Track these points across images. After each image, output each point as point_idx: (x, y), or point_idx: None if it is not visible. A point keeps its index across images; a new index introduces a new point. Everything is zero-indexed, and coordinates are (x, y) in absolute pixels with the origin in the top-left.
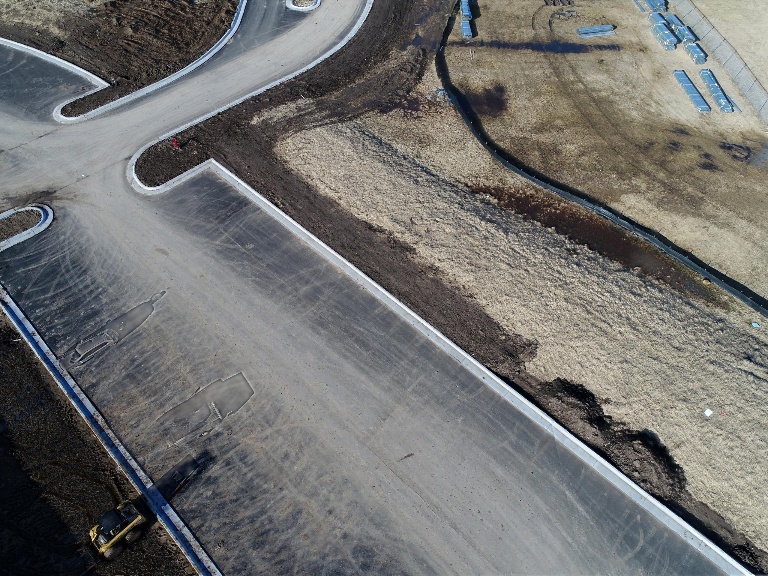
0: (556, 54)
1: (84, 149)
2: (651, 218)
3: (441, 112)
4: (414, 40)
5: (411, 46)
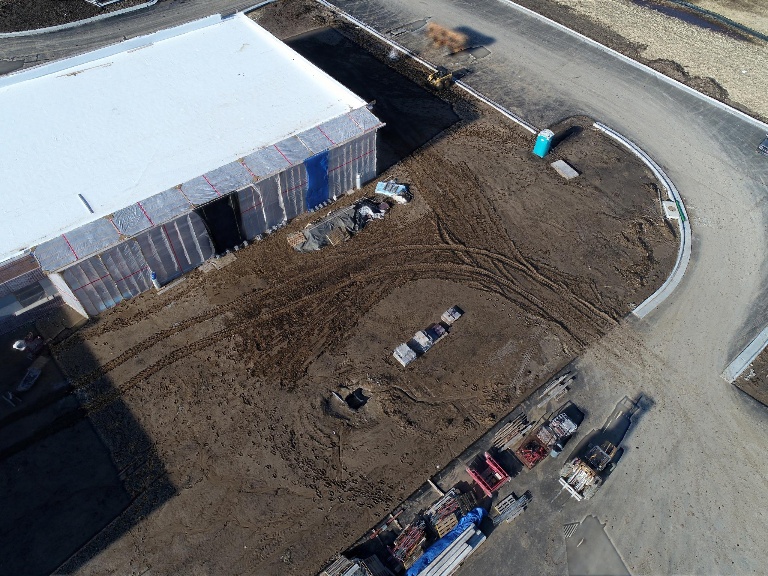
0: None
1: None
2: (719, 10)
3: None
4: None
5: None
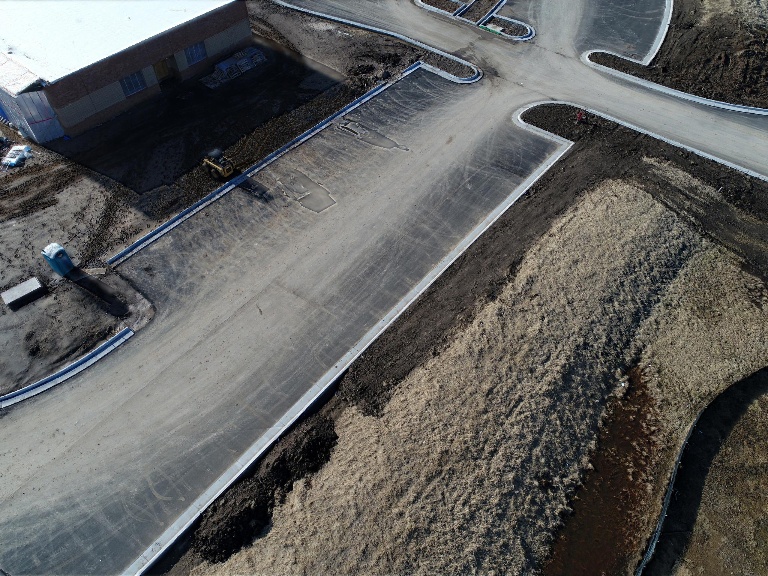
0: None
1: (554, 76)
2: None
3: None
4: None
5: None
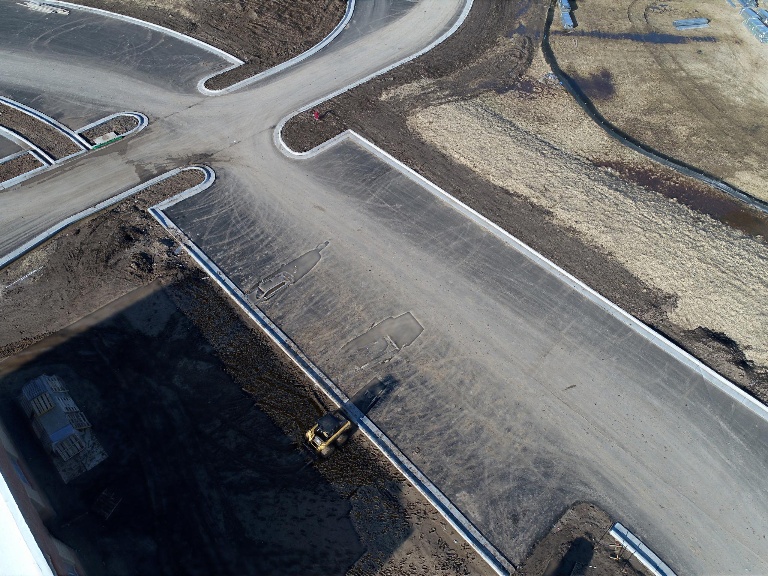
0: (655, 44)
1: (231, 118)
2: (767, 193)
3: (554, 94)
4: (518, 29)
5: (516, 34)
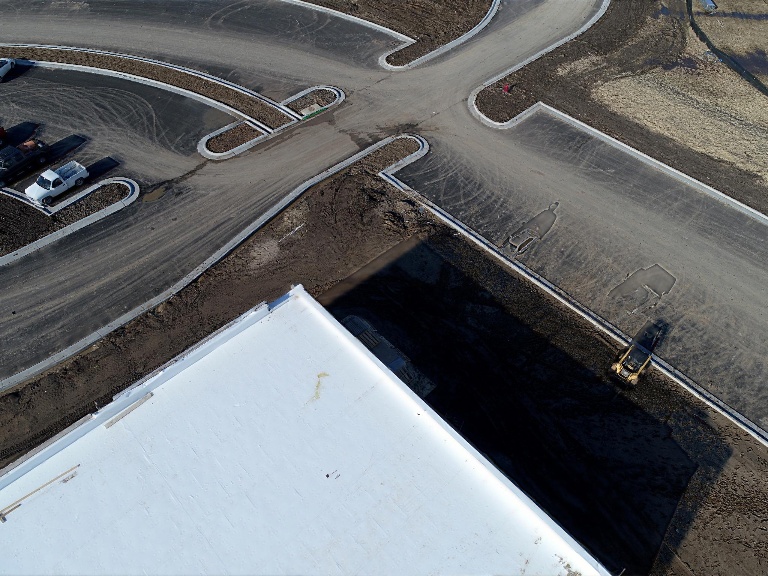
0: None
1: (423, 92)
2: None
3: (718, 70)
4: (662, 10)
5: (662, 15)
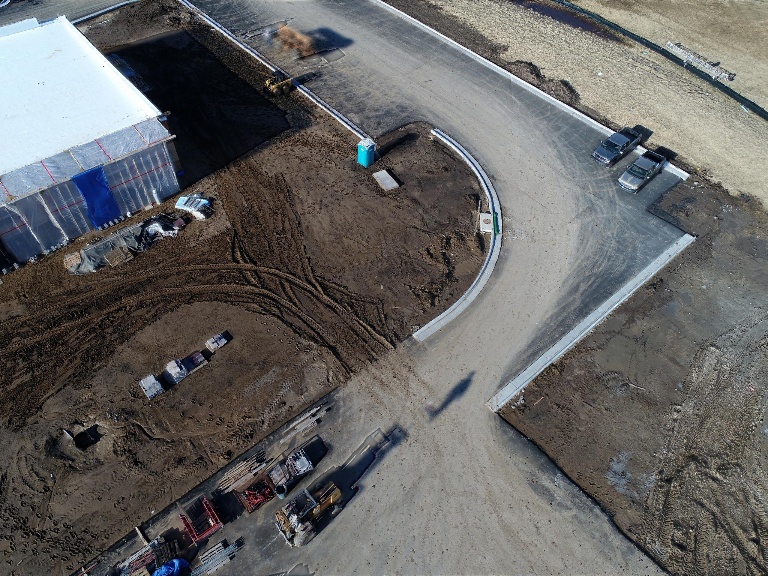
0: None
1: None
2: (596, 9)
3: None
4: None
5: None
